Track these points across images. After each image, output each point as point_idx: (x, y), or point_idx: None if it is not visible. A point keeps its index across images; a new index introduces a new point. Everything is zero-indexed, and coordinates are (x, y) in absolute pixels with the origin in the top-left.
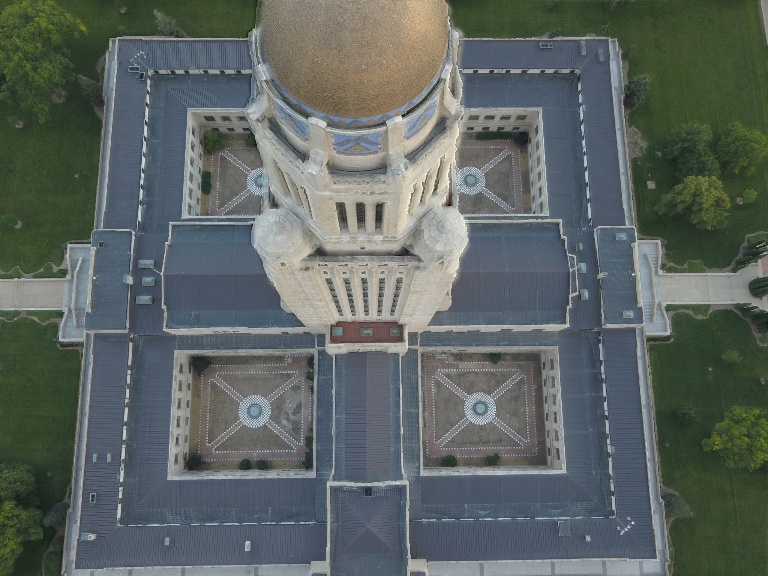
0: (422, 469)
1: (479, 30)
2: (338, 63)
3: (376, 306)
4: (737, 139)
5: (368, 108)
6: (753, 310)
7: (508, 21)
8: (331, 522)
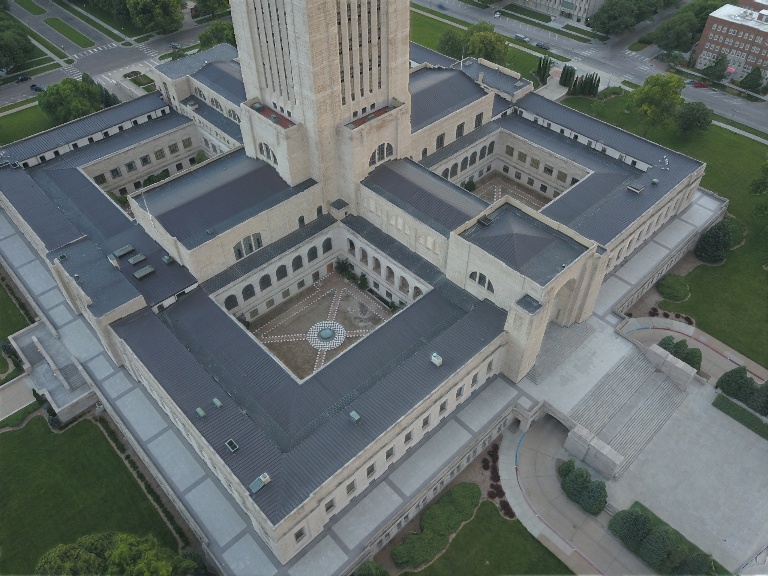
0: None
1: None
2: None
3: (367, 33)
4: (472, 31)
5: None
6: (577, 83)
7: None
8: None
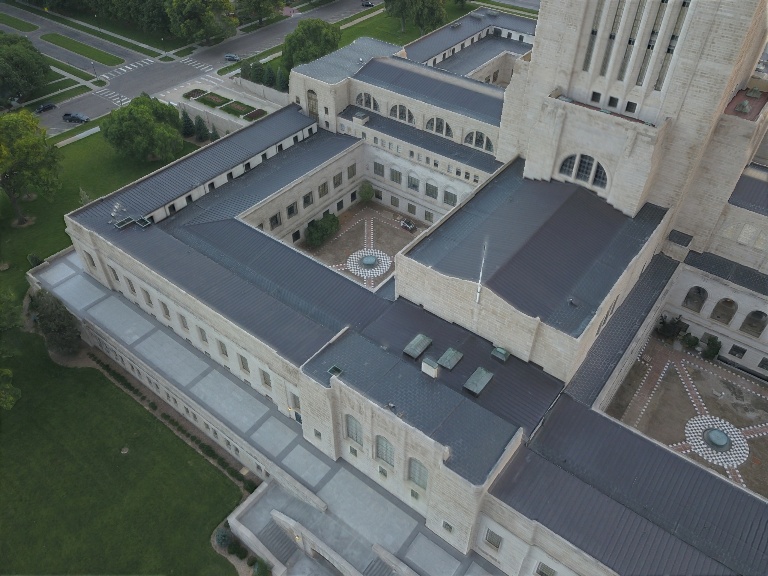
0: None
1: None
2: None
3: None
4: None
5: None
6: None
7: None
8: None
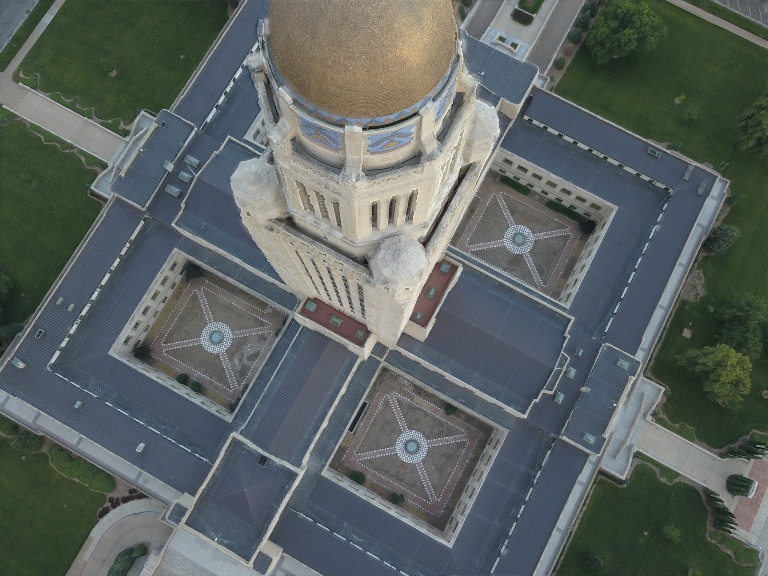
0: (325, 469)
1: (605, 108)
2: (308, 49)
3: (347, 301)
4: None
5: (328, 105)
6: (718, 502)
7: (637, 113)
8: (217, 468)
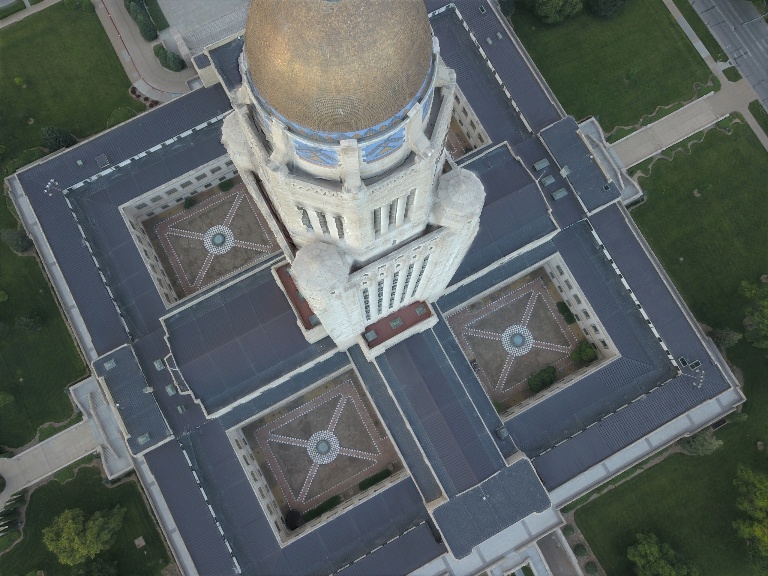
0: None
1: None
2: None
3: None
4: None
5: None
6: None
7: None
8: None
